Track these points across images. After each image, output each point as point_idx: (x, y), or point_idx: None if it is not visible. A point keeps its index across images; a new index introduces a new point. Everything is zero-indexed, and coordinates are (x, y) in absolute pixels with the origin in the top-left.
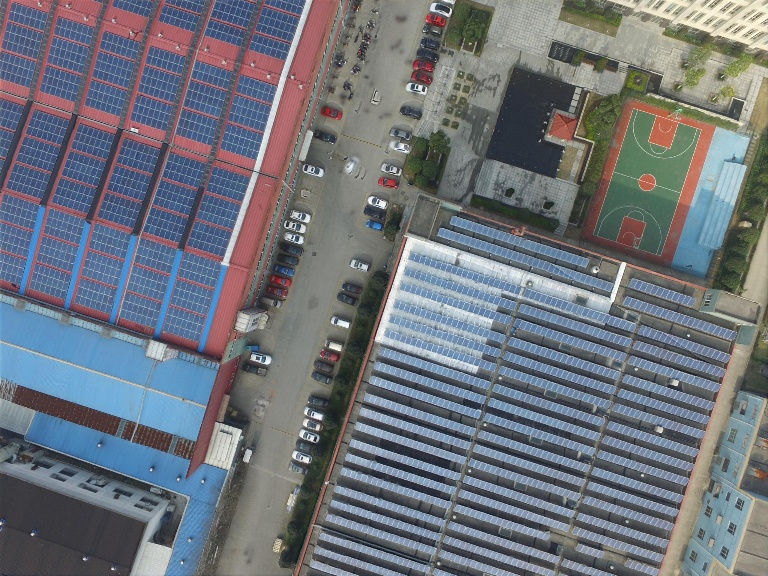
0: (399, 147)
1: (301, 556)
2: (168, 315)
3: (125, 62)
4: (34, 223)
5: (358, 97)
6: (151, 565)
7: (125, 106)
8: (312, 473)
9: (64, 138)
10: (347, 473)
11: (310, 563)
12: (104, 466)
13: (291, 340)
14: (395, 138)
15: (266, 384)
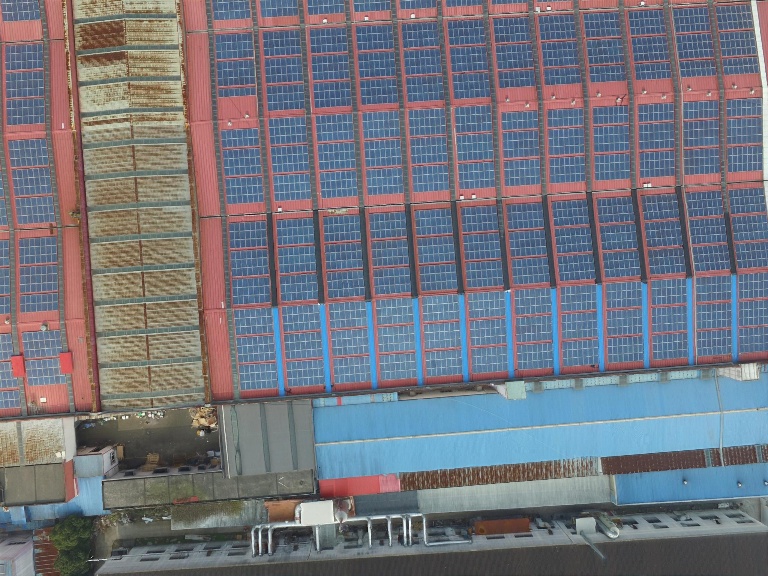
0: None
1: None
2: (739, 337)
3: (620, 128)
4: (595, 303)
5: None
6: None
7: (631, 167)
8: None
9: (589, 217)
10: None
11: None
12: (696, 499)
13: None
14: None
15: None
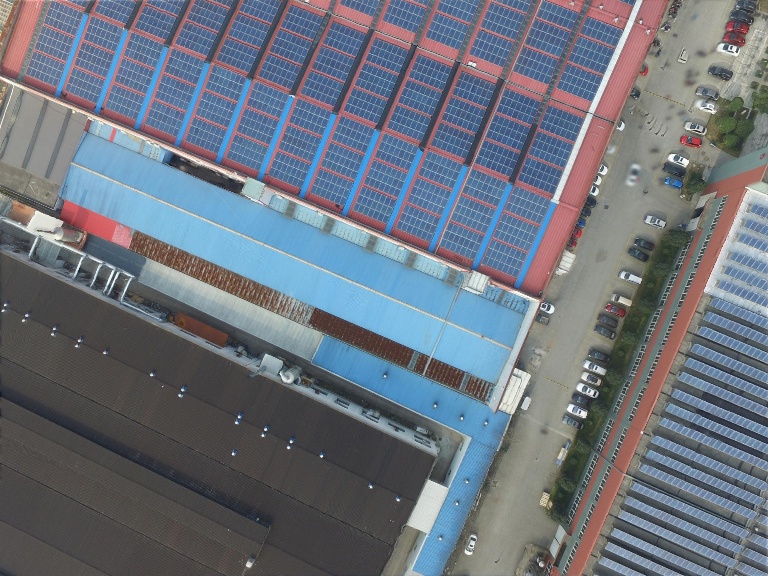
0: (707, 106)
1: (609, 505)
2: (489, 248)
3: None
4: (367, 146)
5: (665, 54)
6: (426, 502)
7: (465, 40)
8: (585, 429)
9: (402, 67)
10: (668, 424)
11: (620, 513)
12: (388, 397)
13: (575, 292)
14: (701, 97)
15: (545, 334)
